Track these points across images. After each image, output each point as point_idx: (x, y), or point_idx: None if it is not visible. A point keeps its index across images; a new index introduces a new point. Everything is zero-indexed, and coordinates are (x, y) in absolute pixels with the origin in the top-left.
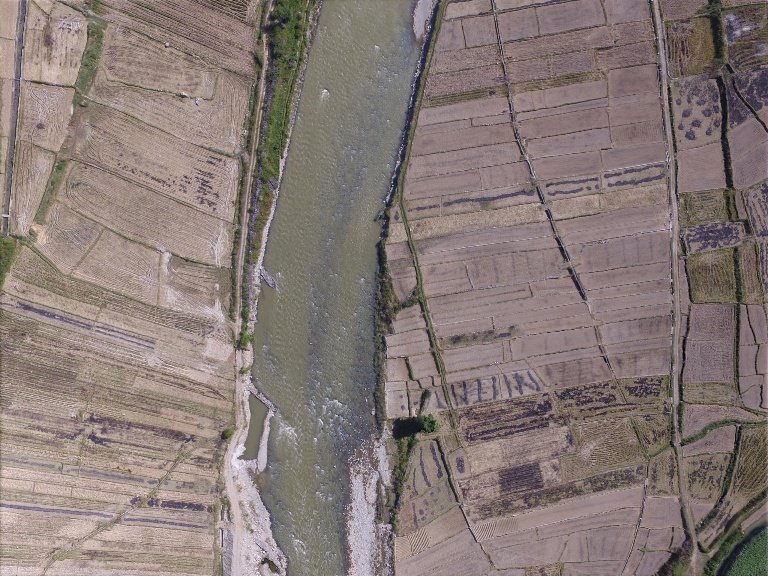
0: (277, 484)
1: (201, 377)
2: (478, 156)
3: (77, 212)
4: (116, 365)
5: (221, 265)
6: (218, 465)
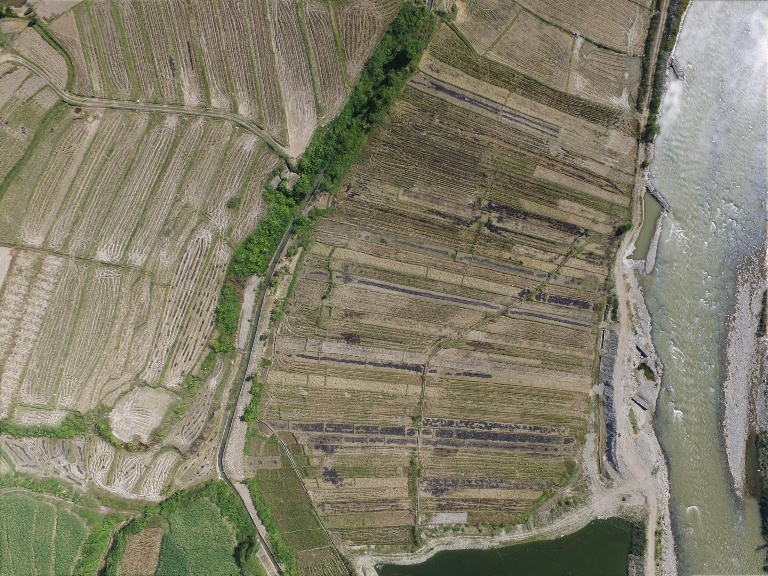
0: (663, 287)
1: (600, 170)
2: None
3: None
4: (518, 152)
5: (633, 53)
6: (609, 262)
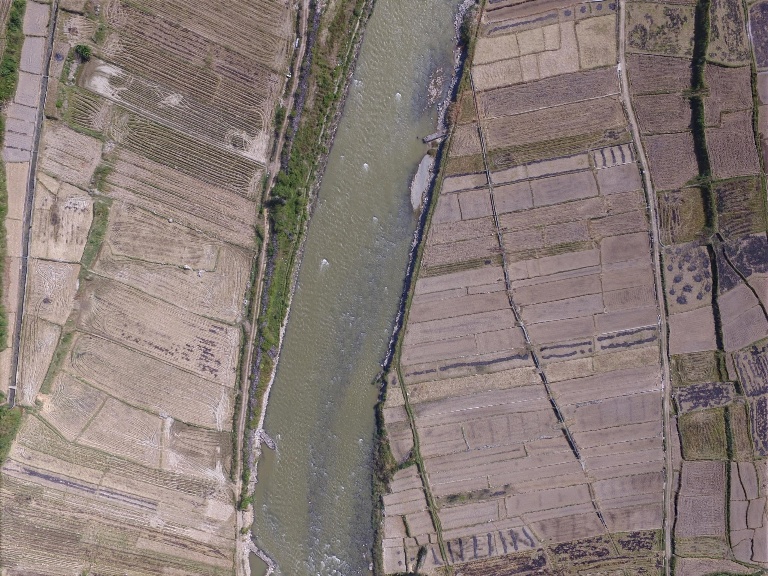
0: None
1: (202, 537)
2: (474, 322)
3: (82, 381)
4: (119, 527)
5: (222, 429)
6: None
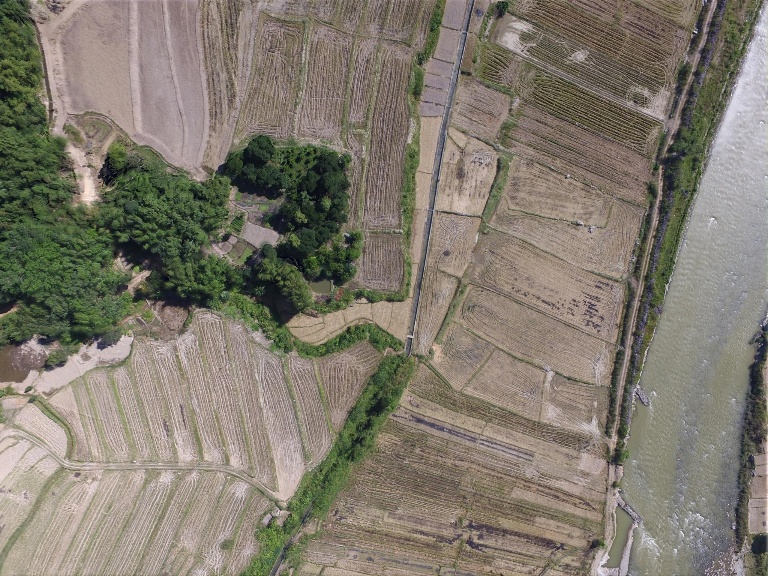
0: None
1: (573, 489)
2: None
3: (472, 333)
4: (496, 476)
5: (601, 384)
6: (584, 572)
